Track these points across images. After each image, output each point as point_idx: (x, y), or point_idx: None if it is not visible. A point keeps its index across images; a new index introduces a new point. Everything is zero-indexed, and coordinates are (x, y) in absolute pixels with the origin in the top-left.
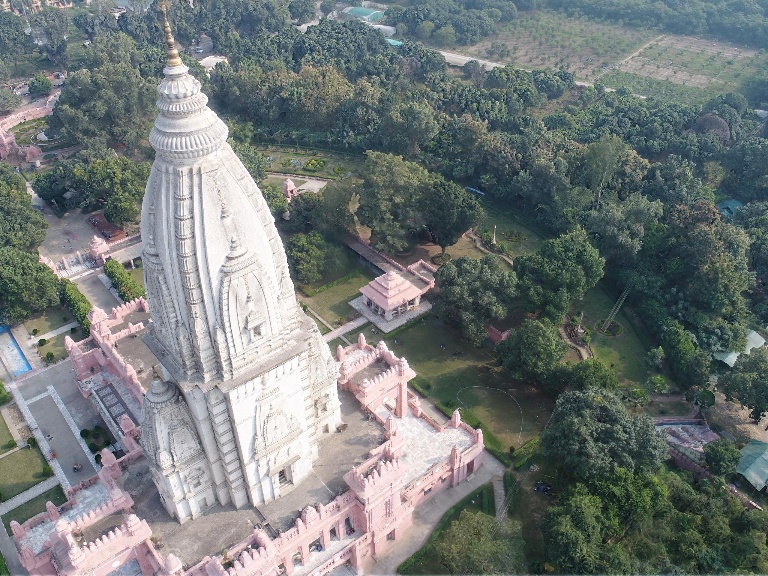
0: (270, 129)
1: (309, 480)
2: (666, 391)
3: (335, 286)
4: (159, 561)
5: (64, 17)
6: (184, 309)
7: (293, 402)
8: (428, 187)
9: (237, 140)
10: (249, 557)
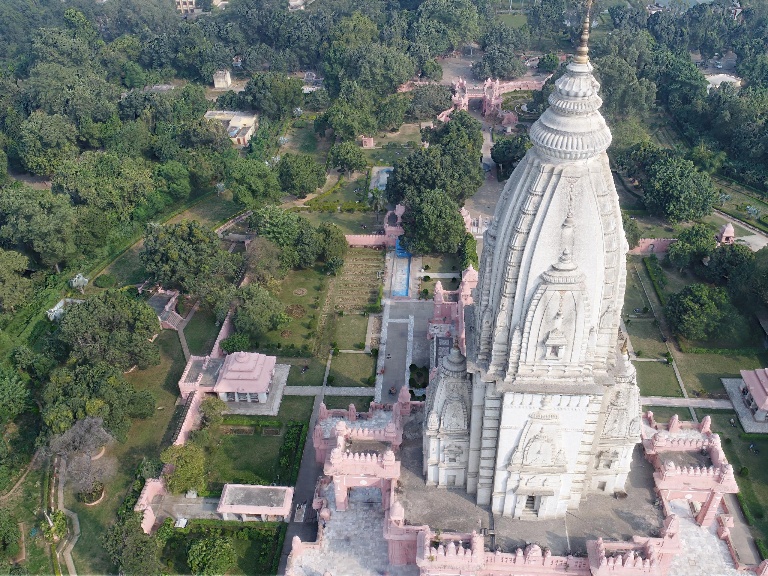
0: (744, 166)
1: (555, 522)
2: None
3: (717, 354)
4: (391, 502)
5: (600, 5)
6: (496, 297)
7: (568, 438)
8: None
9: (700, 166)
10: (454, 550)
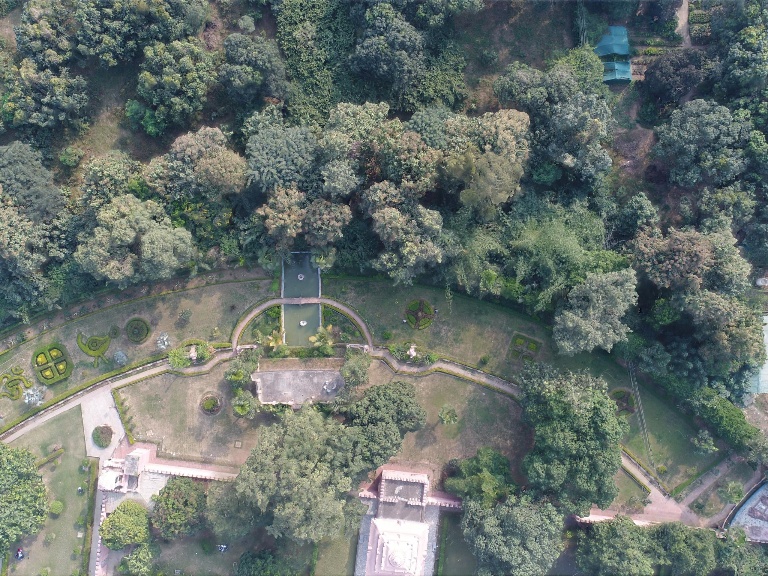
0: None
1: None
2: (743, 493)
3: (317, 563)
4: None
5: None
6: None
7: None
8: (360, 470)
9: None
10: None
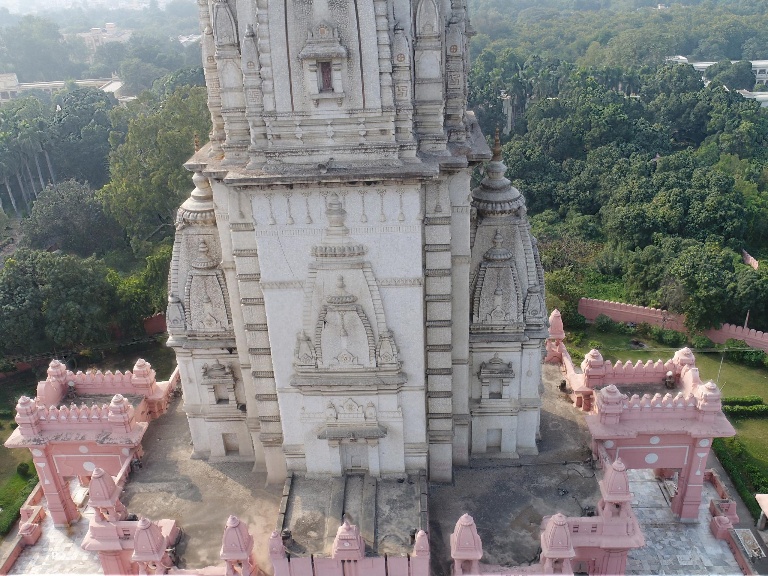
0: None
1: None
2: None
3: None
4: None
5: None
6: None
7: None
8: None
9: None
10: None
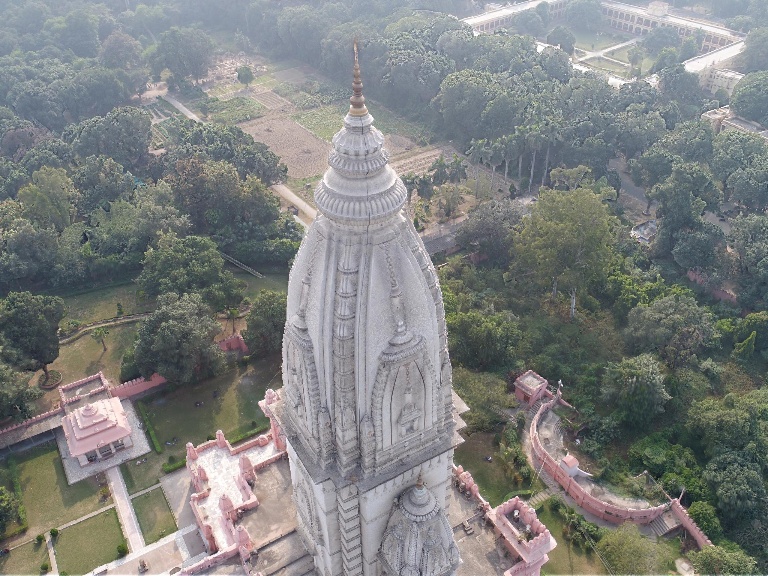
0: None
1: None
2: None
3: (24, 497)
4: None
5: None
6: None
7: None
8: (5, 314)
9: None
10: None
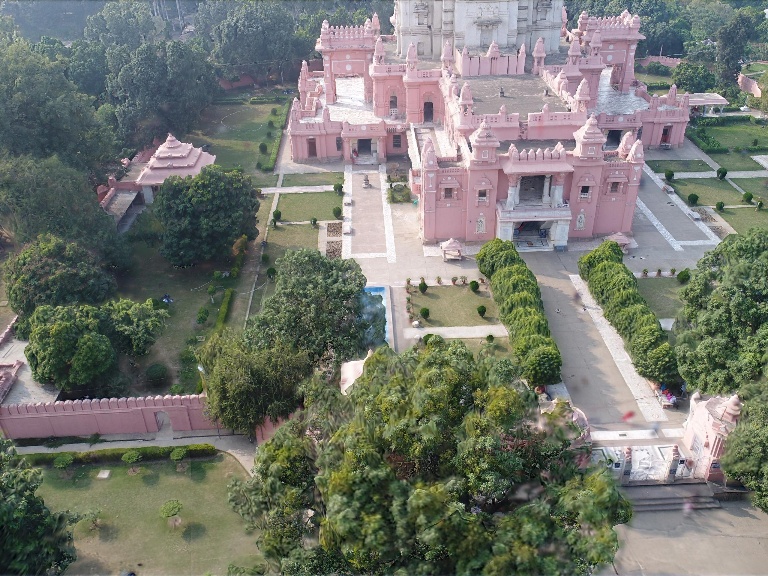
0: None
1: None
2: None
3: None
4: None
5: None
6: None
7: None
8: None
9: None
10: None
